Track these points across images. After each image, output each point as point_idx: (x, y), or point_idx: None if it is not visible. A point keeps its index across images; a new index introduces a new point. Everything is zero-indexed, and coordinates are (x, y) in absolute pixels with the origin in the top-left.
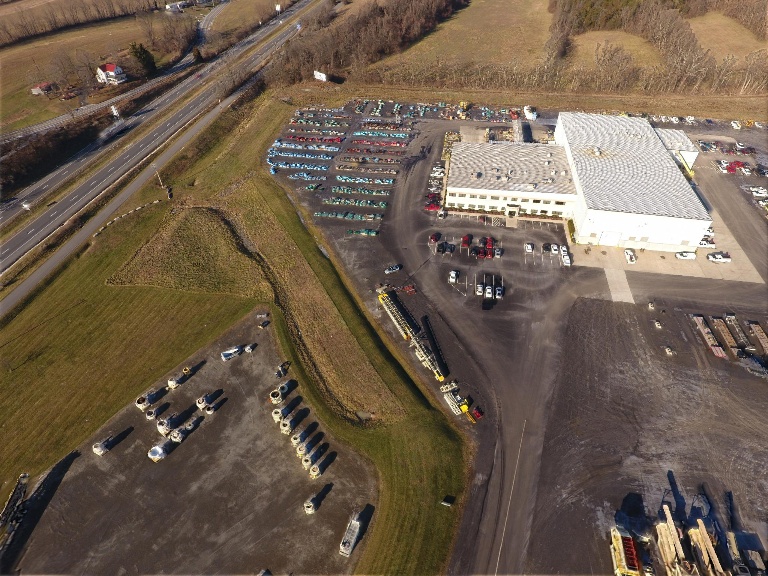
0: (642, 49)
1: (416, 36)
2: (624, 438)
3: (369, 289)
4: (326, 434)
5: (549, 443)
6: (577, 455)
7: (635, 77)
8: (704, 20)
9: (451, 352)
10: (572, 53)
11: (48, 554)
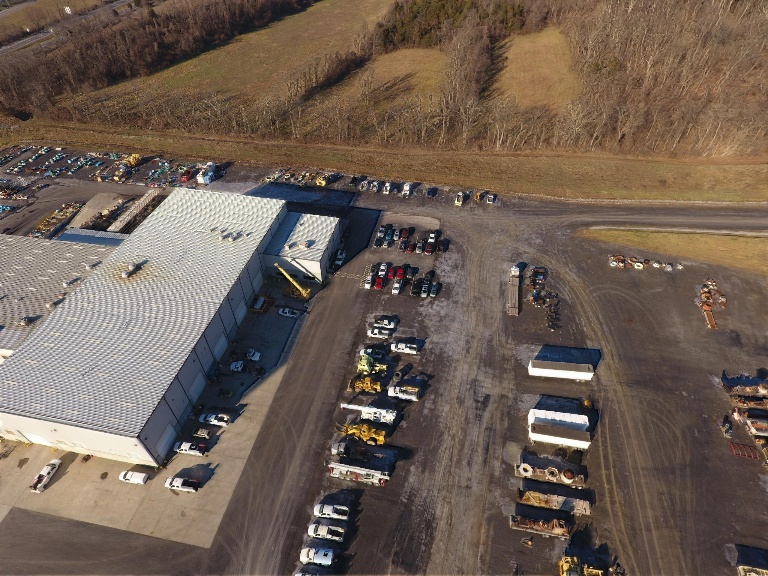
0: (436, 77)
1: (188, 52)
2: None
3: None
4: None
5: None
6: None
7: None
8: (537, 38)
9: None
10: (348, 80)
11: None
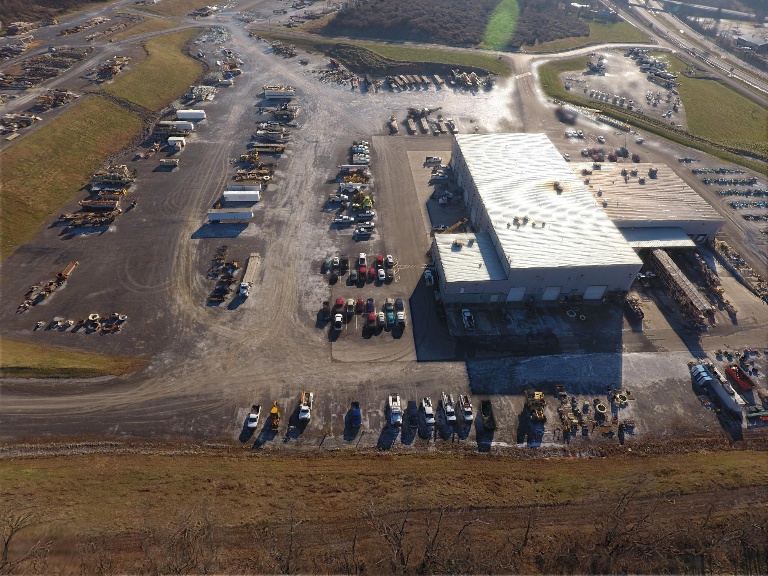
0: None
1: None
2: None
3: None
4: (600, 100)
5: (519, 97)
6: (508, 96)
7: None
8: None
9: (574, 114)
10: None
11: (647, 83)
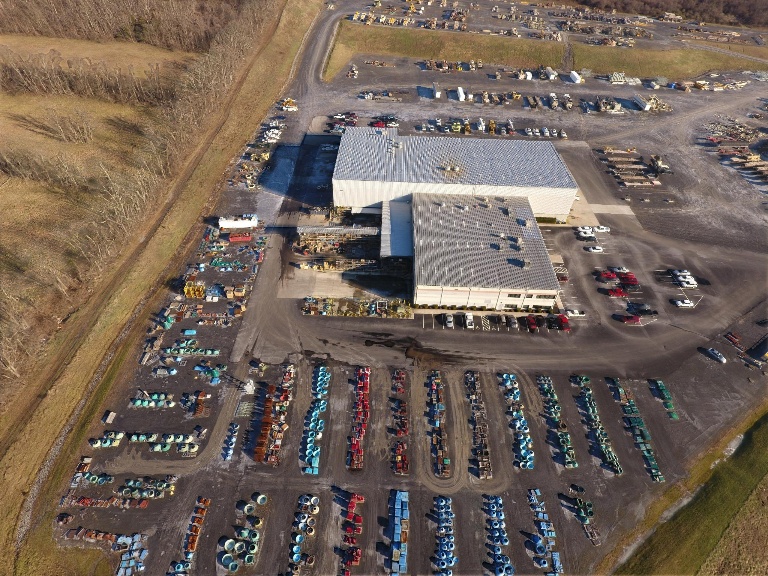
0: (40, 103)
1: None
2: (767, 230)
3: (764, 376)
4: None
5: None
6: None
7: (137, 128)
8: None
9: None
10: None
11: None
